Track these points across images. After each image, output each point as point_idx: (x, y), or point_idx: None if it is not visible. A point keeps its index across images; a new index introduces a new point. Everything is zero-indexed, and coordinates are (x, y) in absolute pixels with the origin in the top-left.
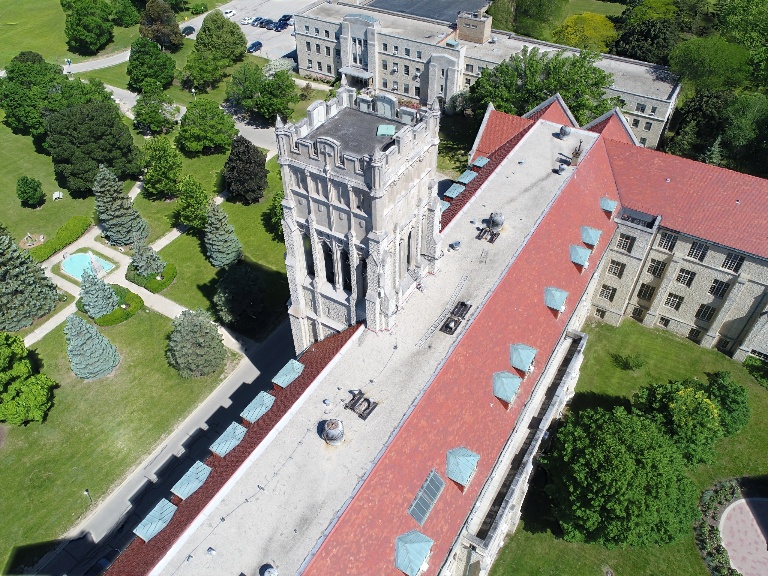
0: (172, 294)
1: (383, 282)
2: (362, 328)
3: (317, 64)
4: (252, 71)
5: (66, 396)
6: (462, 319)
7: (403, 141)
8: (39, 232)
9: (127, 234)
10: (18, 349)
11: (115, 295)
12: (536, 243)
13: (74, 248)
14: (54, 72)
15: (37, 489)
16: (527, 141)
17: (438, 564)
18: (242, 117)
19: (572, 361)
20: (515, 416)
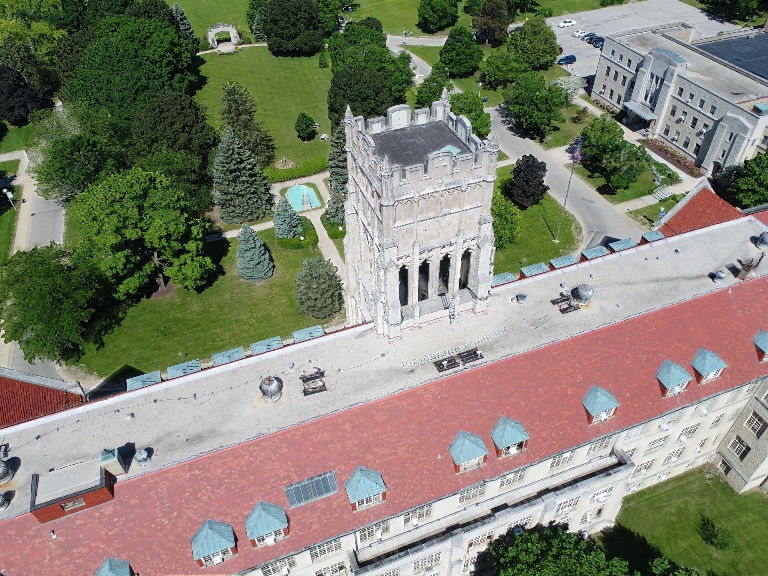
0: (341, 245)
1: (384, 288)
2: (371, 325)
3: (610, 91)
4: (536, 80)
5: (223, 284)
6: (462, 364)
7: (433, 163)
8: (294, 159)
9: (343, 184)
10: (195, 231)
11: (301, 227)
12: (611, 335)
13: (306, 181)
14: (378, 39)
15: (163, 335)
16: (710, 232)
17: (289, 550)
18: (509, 121)
19: (591, 478)
20: (464, 484)
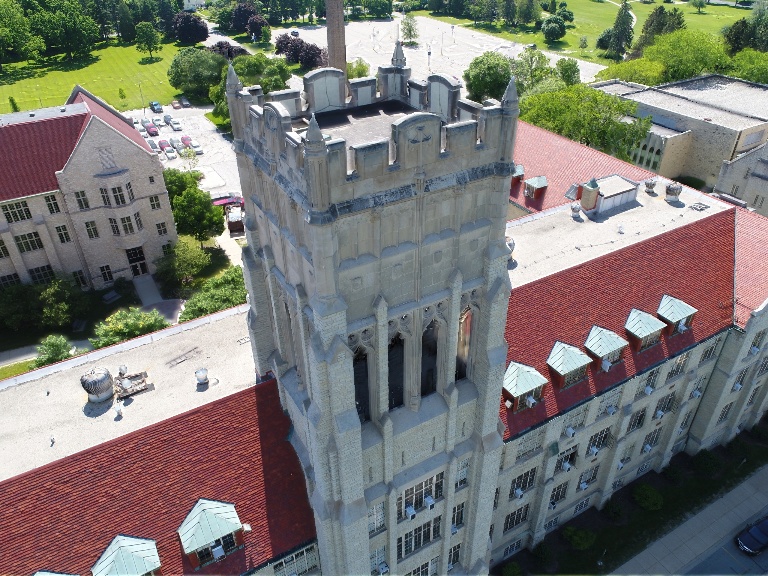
0: None
1: None
2: None
3: None
4: None
5: None
6: None
7: None
8: None
9: None
10: None
11: None
12: None
13: None
14: None
15: None
16: None
17: None
18: None
19: None
20: None
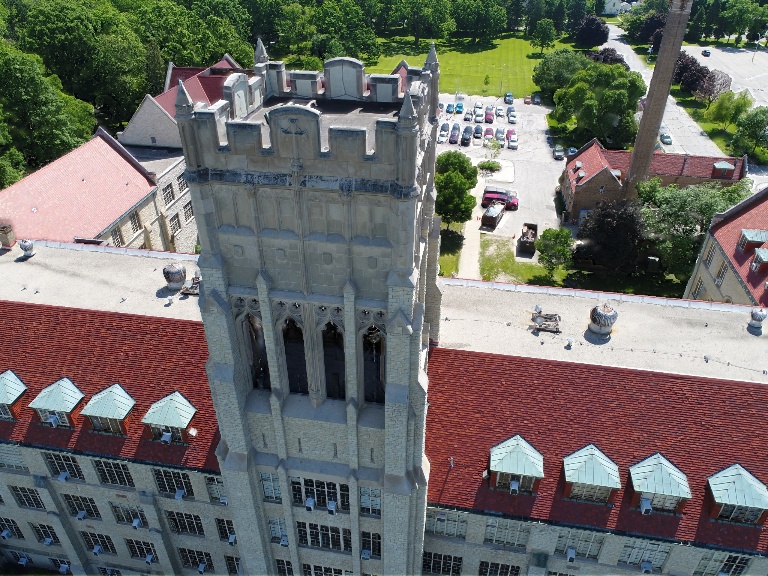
0: None
1: None
2: None
3: None
4: None
5: None
6: None
7: None
8: None
9: None
10: None
11: None
12: None
13: None
14: None
15: None
16: None
17: None
18: None
19: None
20: None
